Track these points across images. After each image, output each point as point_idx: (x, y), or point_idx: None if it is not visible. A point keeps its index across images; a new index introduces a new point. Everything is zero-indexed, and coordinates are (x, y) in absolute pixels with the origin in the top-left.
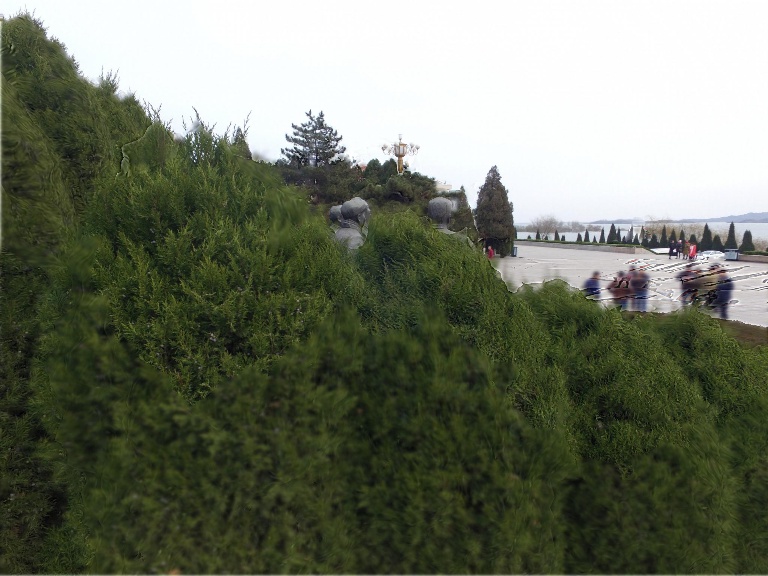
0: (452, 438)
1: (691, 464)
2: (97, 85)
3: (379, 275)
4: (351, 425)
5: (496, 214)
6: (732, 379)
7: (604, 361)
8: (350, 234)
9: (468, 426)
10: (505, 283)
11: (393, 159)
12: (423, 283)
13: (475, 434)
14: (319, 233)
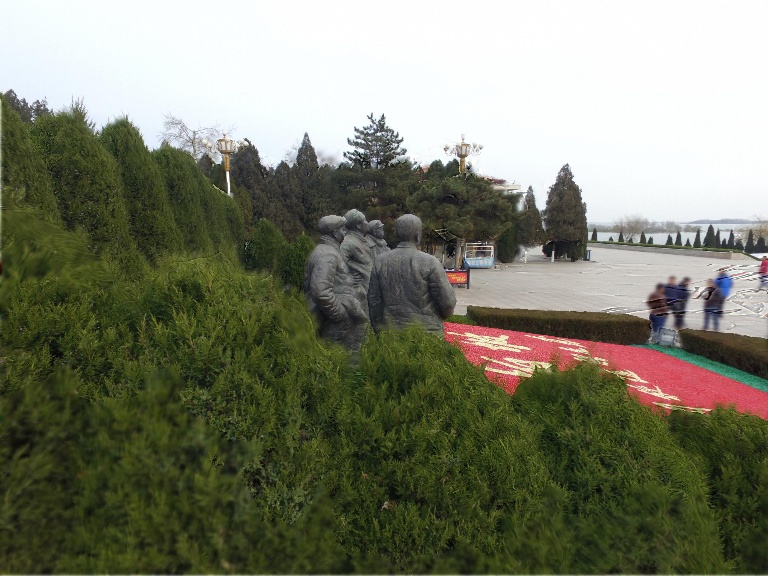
0: (153, 528)
1: (491, 575)
2: (64, 113)
3: (137, 332)
4: (64, 499)
5: (567, 215)
6: (609, 462)
7: (408, 437)
8: (323, 251)
9: (174, 515)
10: (566, 290)
11: (456, 160)
12: (173, 344)
13: (181, 525)
14: (63, 288)
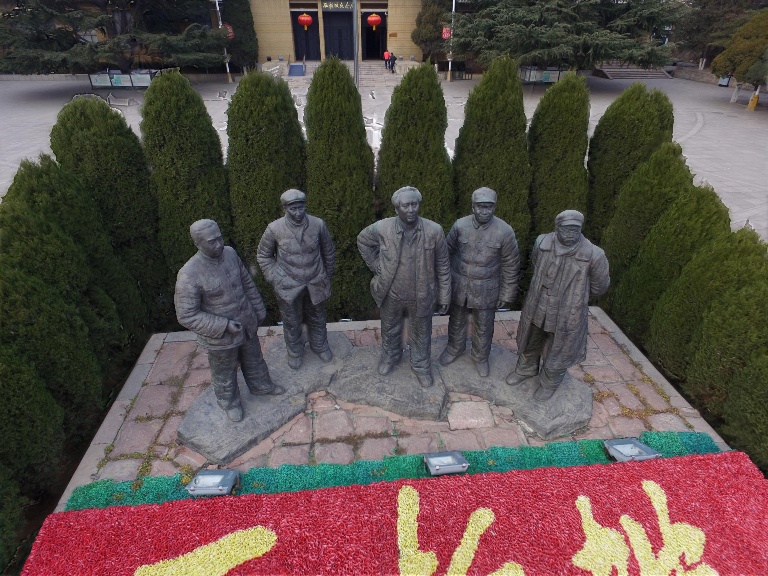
0: None
1: None
2: None
3: None
4: None
5: None
6: None
7: None
8: None
9: None
10: None
11: None
12: None
13: None
14: None
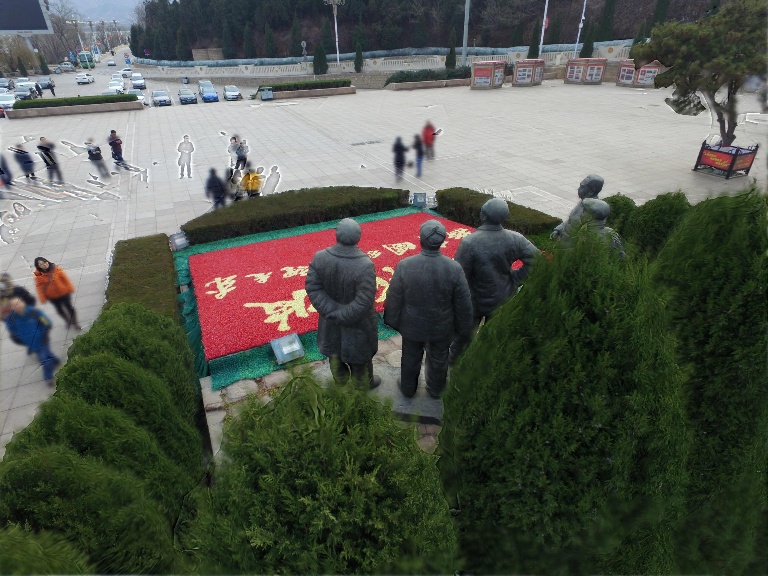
0: None
1: None
2: None
3: None
4: None
5: None
6: None
7: None
8: None
9: None
10: None
11: None
12: None
13: None
14: None
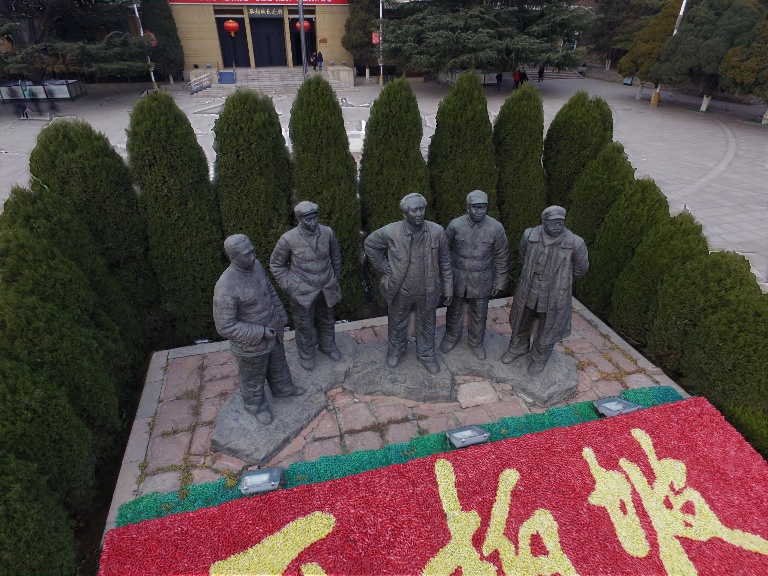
0: None
1: None
2: None
3: None
4: None
5: None
6: None
7: None
8: None
9: None
10: None
11: None
12: None
13: None
14: (2, 227)
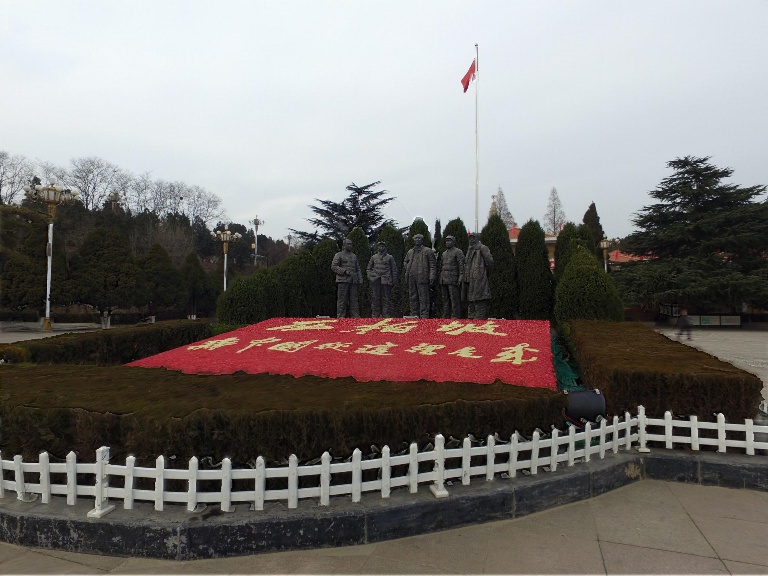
0: None
1: None
2: None
3: None
4: None
5: None
6: None
7: None
8: None
9: None
10: None
11: None
12: None
13: None
14: None
